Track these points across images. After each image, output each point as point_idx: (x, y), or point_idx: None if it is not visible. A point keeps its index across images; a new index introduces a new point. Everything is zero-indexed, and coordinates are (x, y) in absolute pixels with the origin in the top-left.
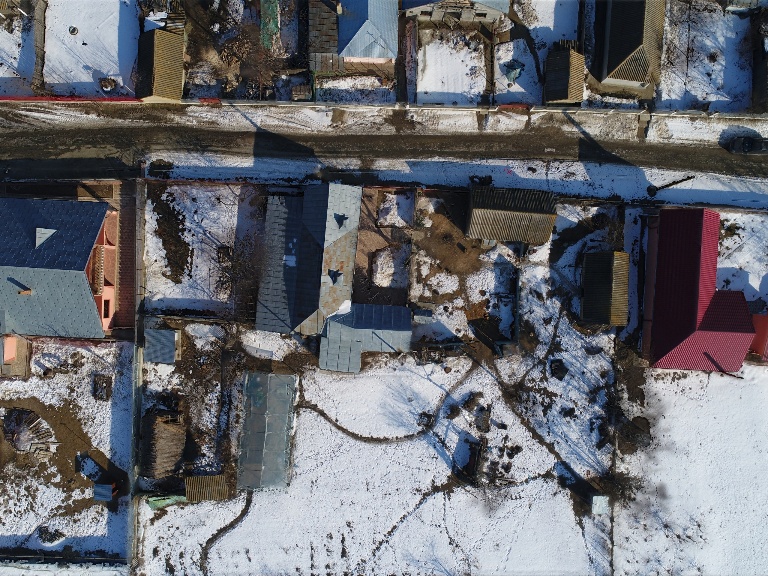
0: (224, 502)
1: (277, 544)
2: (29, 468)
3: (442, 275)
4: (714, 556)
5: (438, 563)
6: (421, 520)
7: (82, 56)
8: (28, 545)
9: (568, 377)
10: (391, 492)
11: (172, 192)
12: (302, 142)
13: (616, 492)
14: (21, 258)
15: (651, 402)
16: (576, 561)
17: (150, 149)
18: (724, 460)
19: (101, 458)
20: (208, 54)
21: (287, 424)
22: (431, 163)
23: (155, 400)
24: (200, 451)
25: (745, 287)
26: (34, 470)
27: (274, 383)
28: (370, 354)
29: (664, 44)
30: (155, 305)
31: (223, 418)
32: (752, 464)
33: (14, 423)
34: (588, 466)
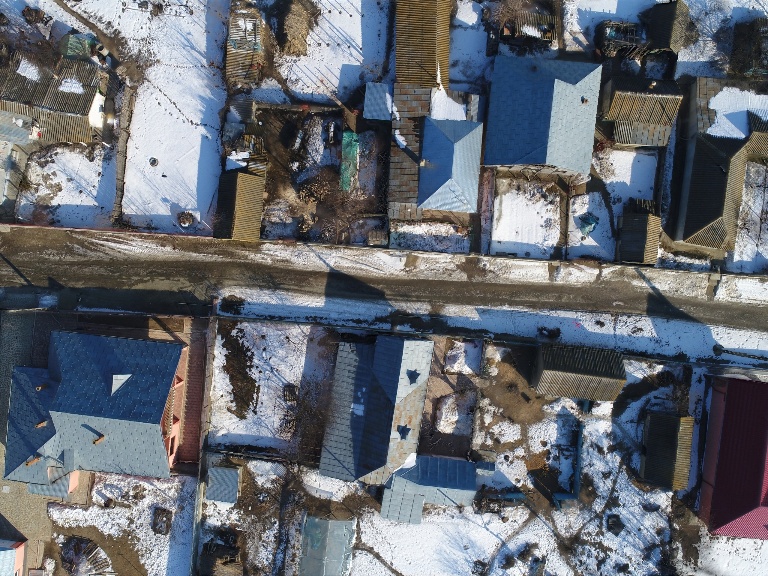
0: None
1: None
2: None
3: (505, 424)
4: None
5: None
6: None
7: (161, 188)
8: None
9: (624, 533)
10: None
11: (242, 328)
12: (374, 284)
13: None
14: (97, 406)
15: (705, 561)
16: None
17: (223, 284)
18: None
19: None
20: (285, 192)
21: (342, 565)
22: (500, 311)
23: (213, 534)
24: None
25: None
26: None
27: (332, 524)
28: None
29: None
30: (219, 440)
31: (279, 556)
32: None
33: (72, 551)
34: None
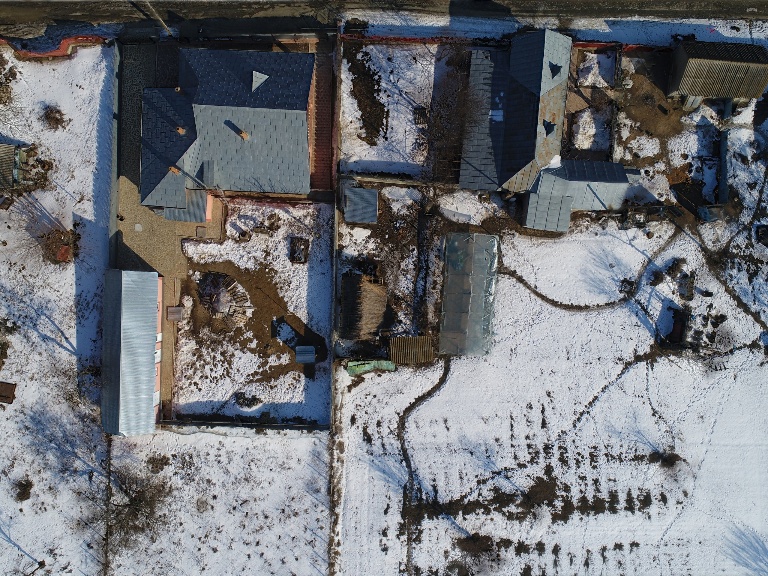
0: (421, 370)
1: (476, 413)
2: (225, 333)
3: (643, 138)
4: None
5: (641, 435)
6: (623, 390)
7: None
8: (225, 411)
9: None
10: (592, 361)
11: (368, 51)
12: (499, 1)
13: None
14: (240, 100)
15: None
16: None
17: (345, 8)
18: None
19: (297, 323)
20: None
21: (485, 290)
22: (631, 22)
23: (350, 265)
24: (397, 317)
25: None
26: (230, 335)
27: (472, 248)
28: (571, 218)
29: None
30: (351, 167)
31: (420, 284)
32: None
33: (210, 287)
34: None
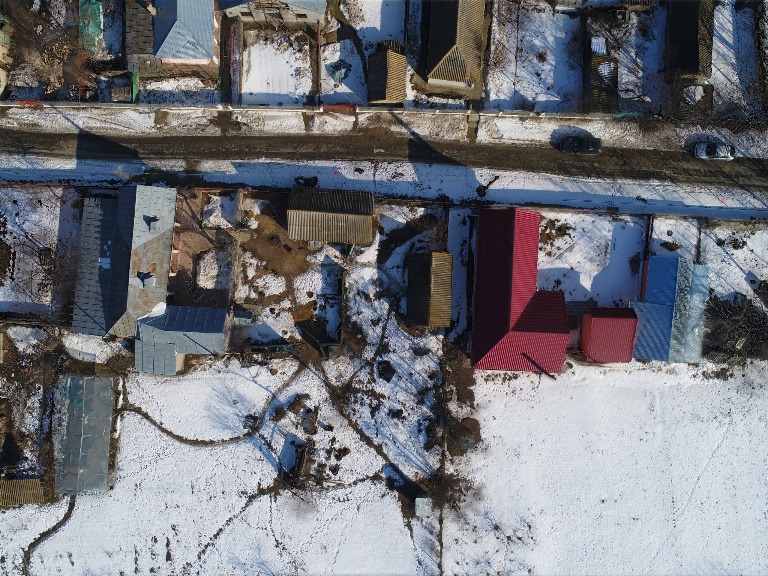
0: (47, 506)
1: (100, 548)
2: None
3: (269, 277)
4: (545, 557)
5: (264, 566)
6: (247, 523)
7: None
8: None
9: (396, 378)
10: (216, 495)
11: None
12: (126, 144)
13: (445, 494)
14: None
15: (481, 403)
16: (404, 563)
17: None
18: (556, 461)
19: None
20: (30, 56)
21: (111, 427)
22: (257, 164)
23: None
24: (22, 455)
25: (576, 287)
26: None
27: (97, 386)
28: (194, 356)
29: (492, 44)
30: None
31: (46, 421)
32: (584, 465)
33: None
34: (416, 468)
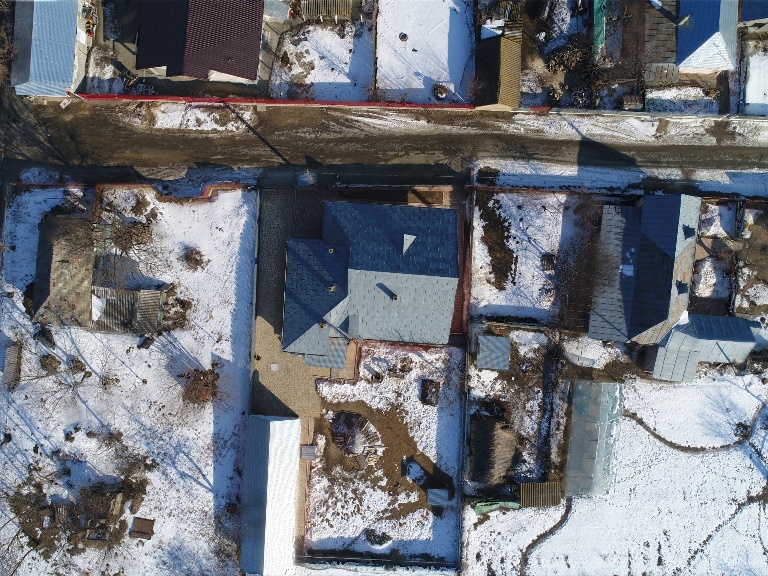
0: (544, 508)
1: (596, 551)
2: (356, 471)
3: (759, 286)
4: None
5: (752, 573)
6: (736, 530)
7: (412, 62)
8: (355, 547)
9: None
10: (707, 501)
11: (499, 199)
12: (625, 151)
13: None
14: (393, 264)
15: None
16: None
17: (477, 156)
18: None
19: (426, 462)
20: (533, 62)
21: (606, 432)
22: (750, 174)
23: (478, 406)
24: (521, 457)
25: None
26: (361, 473)
27: (594, 391)
28: None
29: None
30: (481, 311)
31: (544, 425)
32: None
33: (343, 426)
34: None
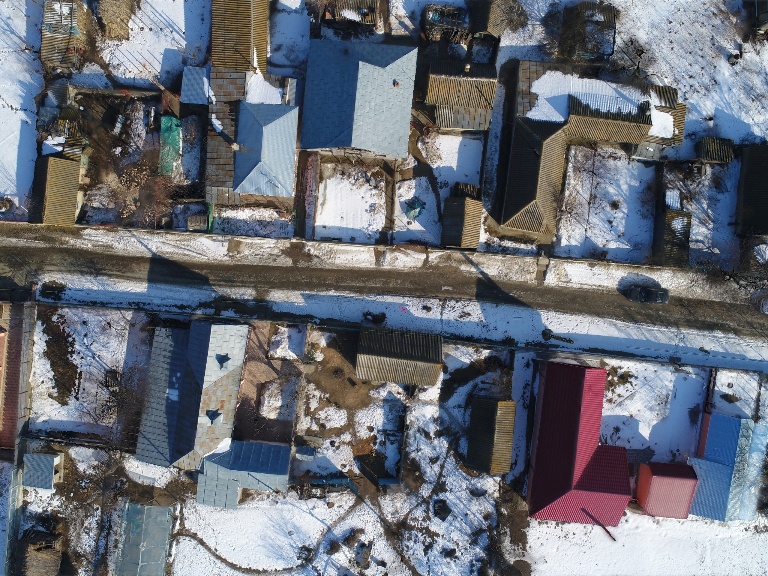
0: None
1: None
2: None
3: (331, 409)
4: None
5: None
6: None
7: None
8: None
9: (451, 518)
10: None
11: (63, 314)
12: (197, 270)
13: None
14: None
15: (533, 546)
16: None
17: (43, 270)
18: None
19: None
20: (108, 177)
21: (166, 551)
22: (326, 297)
23: (34, 521)
24: (77, 574)
25: (634, 436)
26: None
27: (155, 510)
28: None
29: (566, 190)
30: (39, 427)
31: (102, 542)
32: None
33: None
34: None
